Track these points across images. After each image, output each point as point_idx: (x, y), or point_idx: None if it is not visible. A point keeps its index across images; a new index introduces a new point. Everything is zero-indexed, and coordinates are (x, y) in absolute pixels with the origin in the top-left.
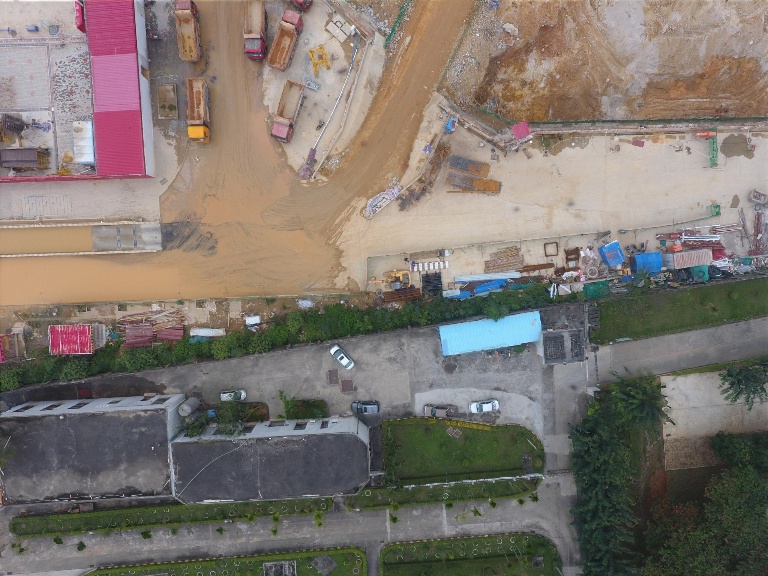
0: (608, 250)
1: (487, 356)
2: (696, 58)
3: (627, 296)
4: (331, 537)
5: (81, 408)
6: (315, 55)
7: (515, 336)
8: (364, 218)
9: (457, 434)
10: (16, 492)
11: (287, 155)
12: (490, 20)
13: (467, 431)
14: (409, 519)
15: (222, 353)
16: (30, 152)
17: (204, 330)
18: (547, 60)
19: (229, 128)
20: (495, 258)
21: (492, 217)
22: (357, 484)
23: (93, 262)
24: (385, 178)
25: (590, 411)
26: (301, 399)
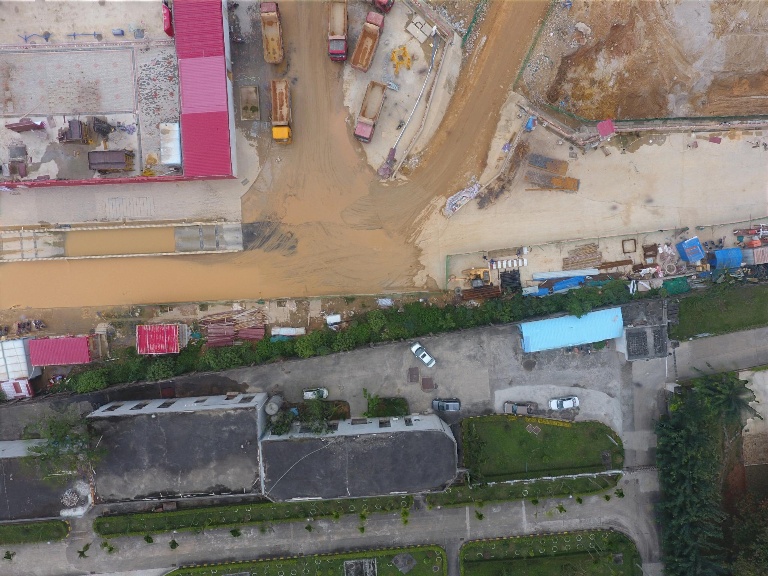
0: (688, 246)
1: (566, 353)
2: (762, 55)
3: (709, 292)
4: (411, 535)
5: (170, 407)
6: (395, 56)
7: (597, 332)
8: (443, 217)
9: (536, 431)
10: (107, 491)
11: (367, 155)
12: (563, 20)
13: (546, 428)
14: (489, 516)
15: (308, 351)
16: (118, 154)
17: (285, 329)
18: (616, 59)
19: (310, 129)
20: (573, 255)
21: (570, 214)
22: (444, 481)
23: (175, 262)
24: (463, 177)
25: (673, 407)
26: (382, 397)
